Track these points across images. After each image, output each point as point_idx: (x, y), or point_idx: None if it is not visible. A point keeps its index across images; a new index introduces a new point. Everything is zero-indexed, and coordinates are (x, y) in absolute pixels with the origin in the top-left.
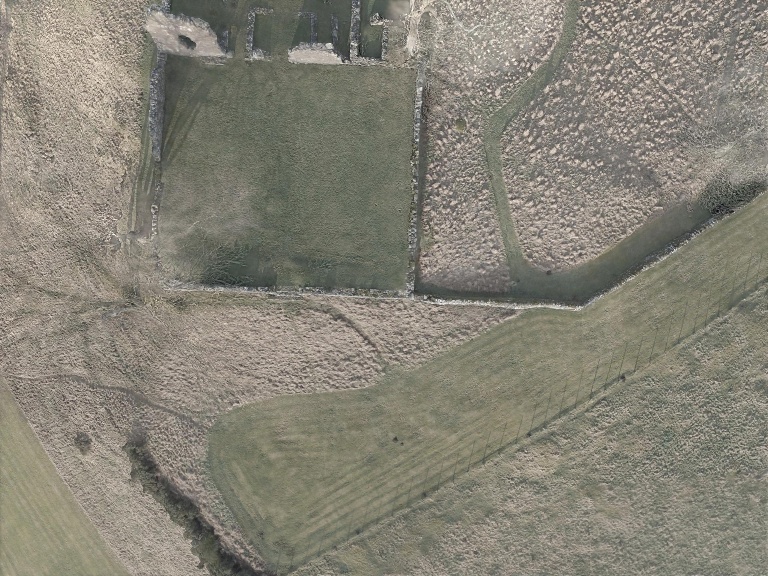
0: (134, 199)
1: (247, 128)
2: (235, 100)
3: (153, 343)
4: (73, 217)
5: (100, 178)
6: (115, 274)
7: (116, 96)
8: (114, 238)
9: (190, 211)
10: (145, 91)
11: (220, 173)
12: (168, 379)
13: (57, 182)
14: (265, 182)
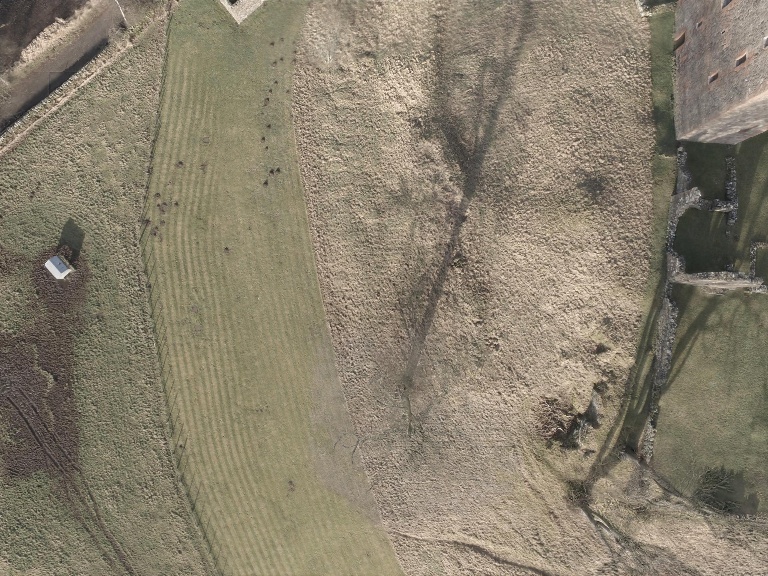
0: (623, 416)
1: (738, 356)
2: (729, 328)
3: (592, 538)
4: (513, 405)
5: (558, 377)
6: (560, 468)
7: (605, 311)
8: (559, 432)
9: (682, 434)
10: (644, 314)
11: (710, 398)
12: (599, 572)
13: (499, 369)
14: (751, 409)
